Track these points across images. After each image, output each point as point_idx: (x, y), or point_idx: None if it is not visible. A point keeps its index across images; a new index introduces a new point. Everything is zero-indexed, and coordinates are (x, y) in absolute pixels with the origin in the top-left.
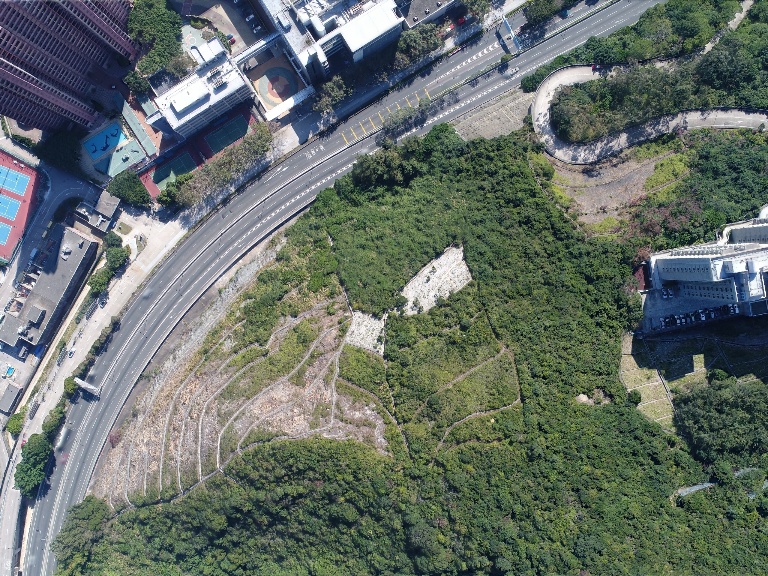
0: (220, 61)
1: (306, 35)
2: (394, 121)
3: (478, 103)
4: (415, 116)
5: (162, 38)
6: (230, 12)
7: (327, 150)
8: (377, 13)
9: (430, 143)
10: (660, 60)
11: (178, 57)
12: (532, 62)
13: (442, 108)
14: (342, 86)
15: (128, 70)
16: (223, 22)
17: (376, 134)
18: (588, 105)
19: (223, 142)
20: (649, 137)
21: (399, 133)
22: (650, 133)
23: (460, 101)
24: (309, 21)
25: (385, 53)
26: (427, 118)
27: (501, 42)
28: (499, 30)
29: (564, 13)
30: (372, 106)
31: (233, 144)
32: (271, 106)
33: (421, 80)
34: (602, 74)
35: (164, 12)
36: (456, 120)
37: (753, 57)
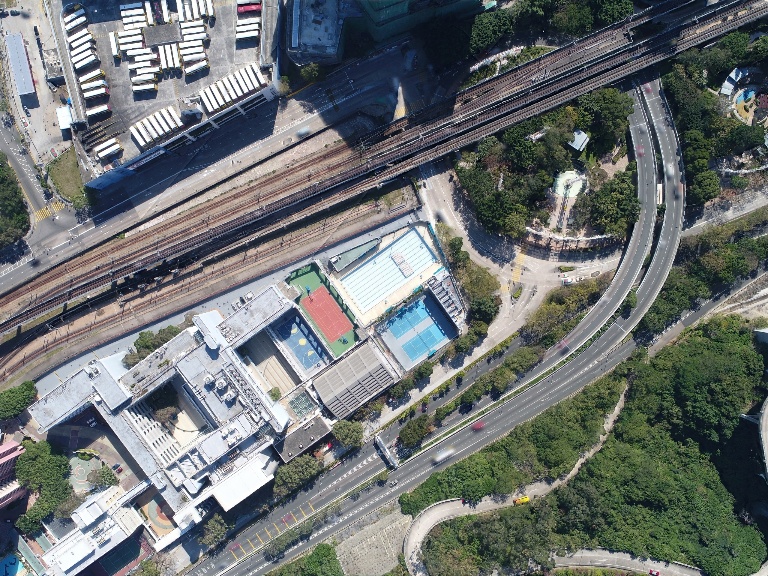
0: (102, 517)
1: (182, 492)
2: (277, 549)
3: (360, 515)
4: (300, 531)
5: (49, 484)
6: (115, 442)
7: (218, 567)
8: (247, 473)
9: (313, 569)
10: (529, 483)
11: (65, 501)
12: (410, 474)
13: (326, 522)
14: (223, 523)
15: (21, 504)
16: (109, 452)
17: (264, 550)
18: (456, 550)
19: (117, 565)
20: (519, 573)
21: (286, 547)
22: (520, 570)
23: (343, 514)
24: (182, 483)
25: (263, 489)
26: (312, 532)
27: (380, 453)
28: (377, 441)
29: (439, 422)
30: (258, 523)
31: (127, 566)
32: (161, 529)
33: (304, 494)
34: (472, 505)
35: (49, 459)
36: (340, 533)
37: (617, 487)
